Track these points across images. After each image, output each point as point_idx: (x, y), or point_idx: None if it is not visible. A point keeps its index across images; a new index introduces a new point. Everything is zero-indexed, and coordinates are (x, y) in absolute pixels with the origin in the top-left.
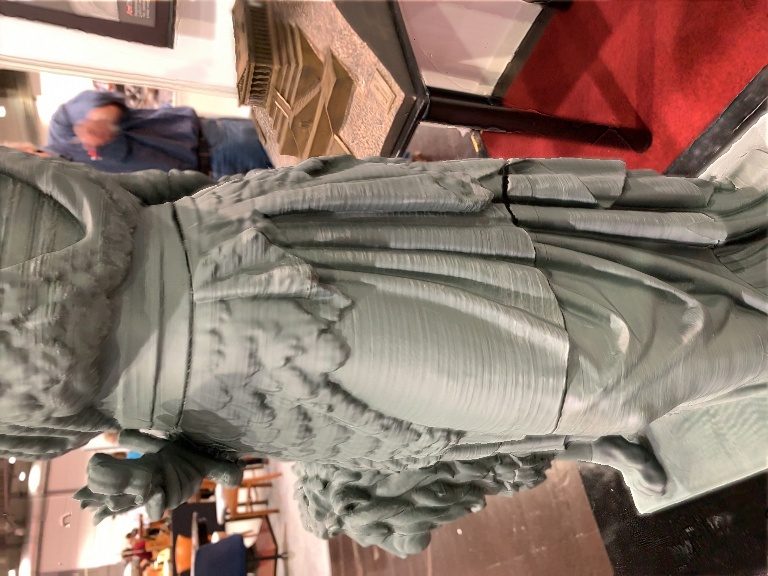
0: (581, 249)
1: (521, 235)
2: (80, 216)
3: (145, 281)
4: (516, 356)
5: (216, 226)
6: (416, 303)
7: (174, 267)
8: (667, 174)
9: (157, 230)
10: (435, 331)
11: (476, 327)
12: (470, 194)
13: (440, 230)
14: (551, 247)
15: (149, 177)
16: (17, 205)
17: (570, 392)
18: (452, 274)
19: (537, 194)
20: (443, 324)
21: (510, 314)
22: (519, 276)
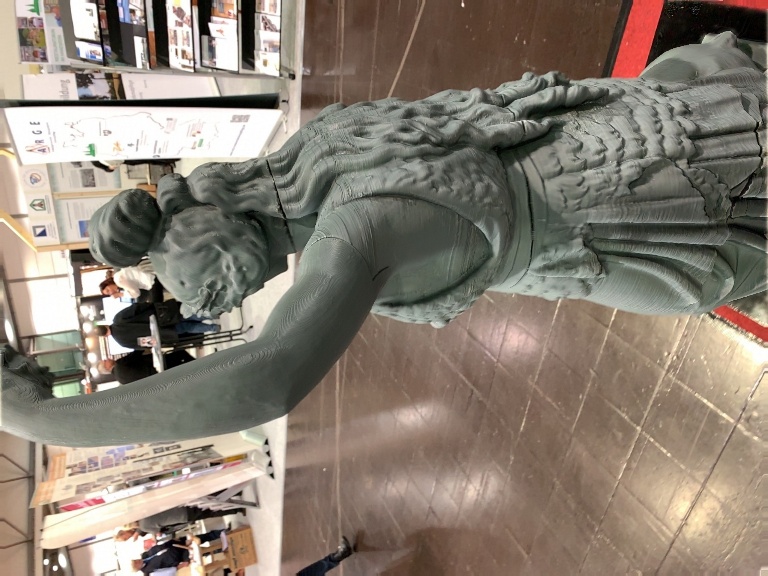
0: (751, 226)
1: (725, 235)
2: (491, 240)
3: (506, 262)
4: (668, 301)
5: (558, 229)
6: (639, 273)
7: (523, 252)
8: None
9: (519, 220)
10: (639, 290)
11: (660, 287)
12: (718, 208)
13: (682, 234)
14: (735, 232)
15: (512, 137)
16: (460, 238)
17: (679, 311)
18: (669, 257)
19: (758, 196)
20: (645, 286)
21: (682, 283)
22: (703, 260)
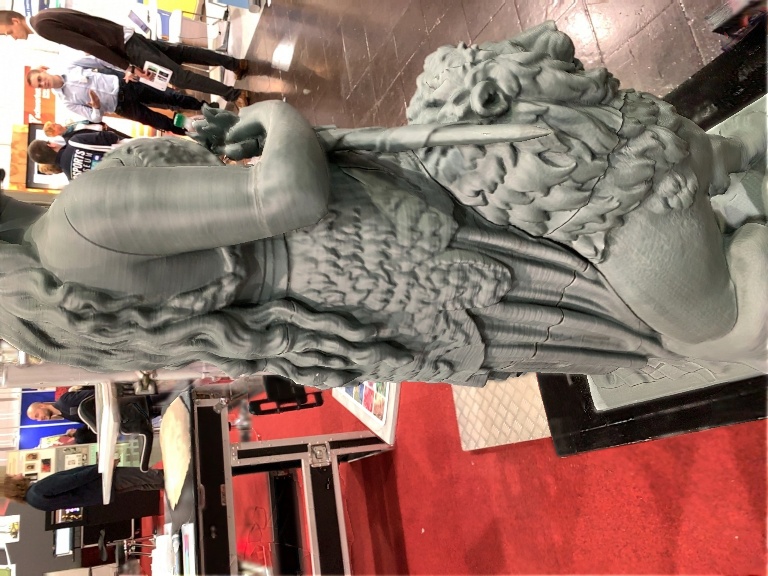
0: None
1: None
2: None
3: None
4: None
5: None
6: None
7: None
8: (698, 425)
9: None
10: None
11: None
12: None
13: None
14: None
15: None
16: None
17: None
18: None
19: None
20: None
21: None
22: None
